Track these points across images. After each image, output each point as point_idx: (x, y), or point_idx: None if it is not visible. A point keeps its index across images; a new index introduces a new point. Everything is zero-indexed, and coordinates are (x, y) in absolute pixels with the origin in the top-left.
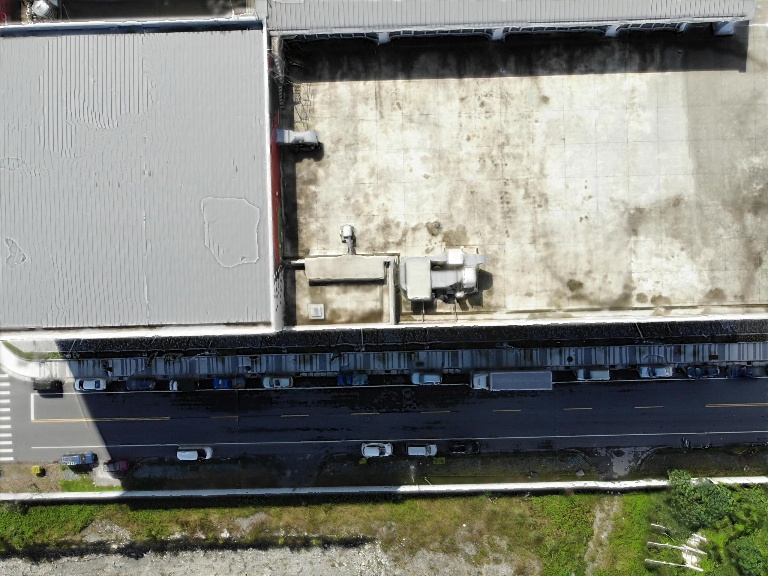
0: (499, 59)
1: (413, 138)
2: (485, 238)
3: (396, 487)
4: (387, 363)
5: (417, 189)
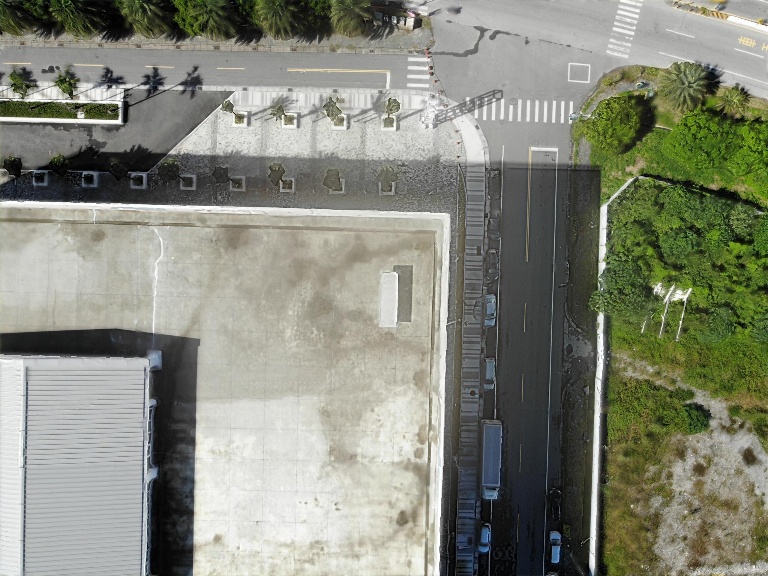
0: None
1: None
2: None
3: (590, 575)
4: (467, 573)
5: None
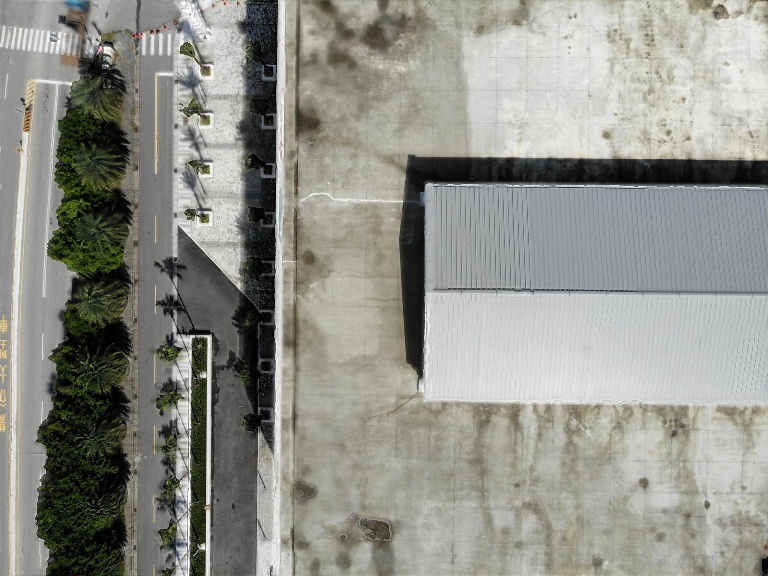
0: (651, 177)
1: (739, 103)
2: (671, 2)
3: None
4: None
5: (737, 52)
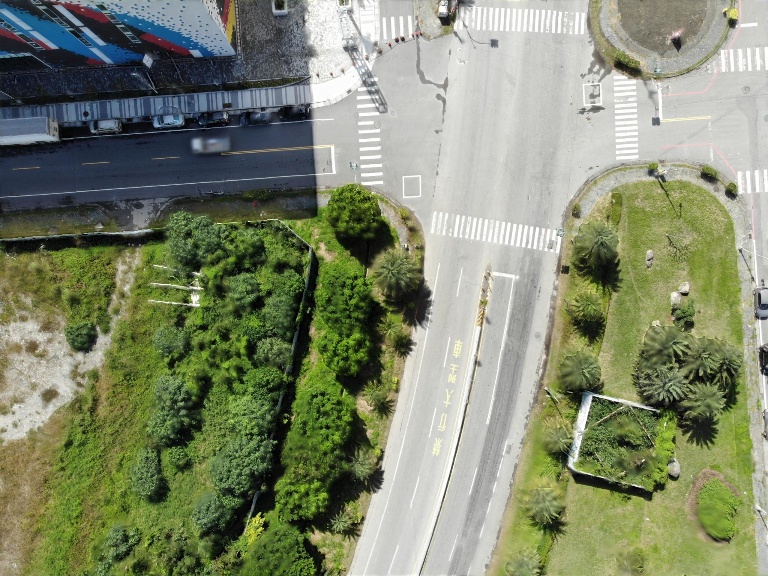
0: None
1: None
2: None
3: None
4: None
5: None
